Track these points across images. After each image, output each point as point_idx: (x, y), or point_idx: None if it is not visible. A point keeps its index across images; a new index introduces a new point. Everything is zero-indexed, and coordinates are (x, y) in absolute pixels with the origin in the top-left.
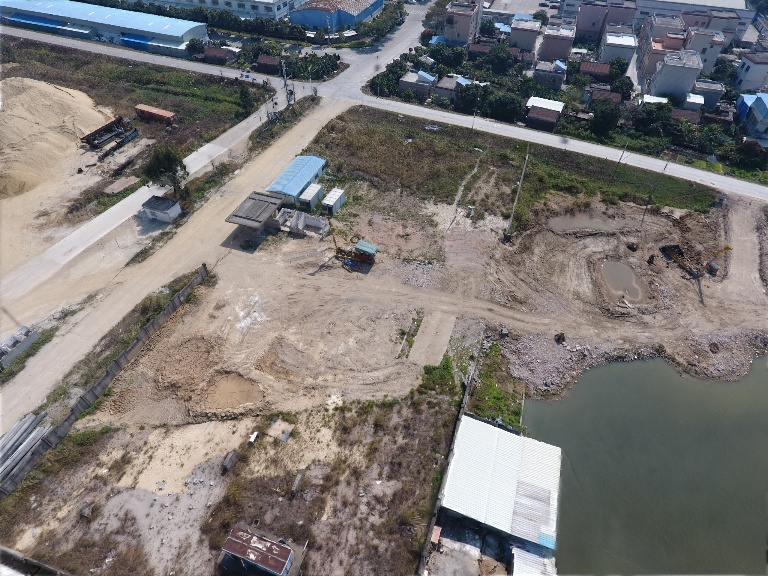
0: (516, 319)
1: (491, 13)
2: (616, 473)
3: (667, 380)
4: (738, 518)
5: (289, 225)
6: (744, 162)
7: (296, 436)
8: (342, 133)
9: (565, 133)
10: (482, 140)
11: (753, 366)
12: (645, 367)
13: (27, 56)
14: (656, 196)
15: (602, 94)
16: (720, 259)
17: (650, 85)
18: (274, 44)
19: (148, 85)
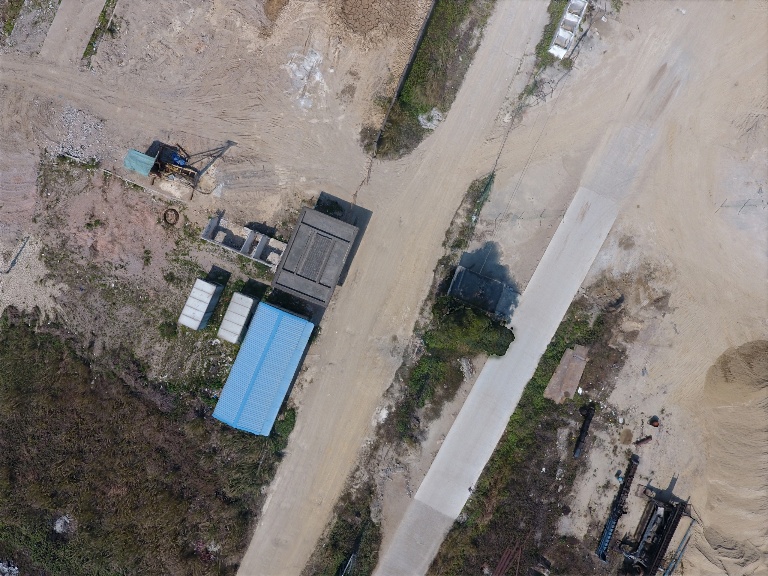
0: None
1: None
2: None
3: None
4: None
5: None
6: None
7: None
8: None
9: None
10: None
11: None
12: None
13: None
14: None
15: None
16: None
17: None
18: None
19: None
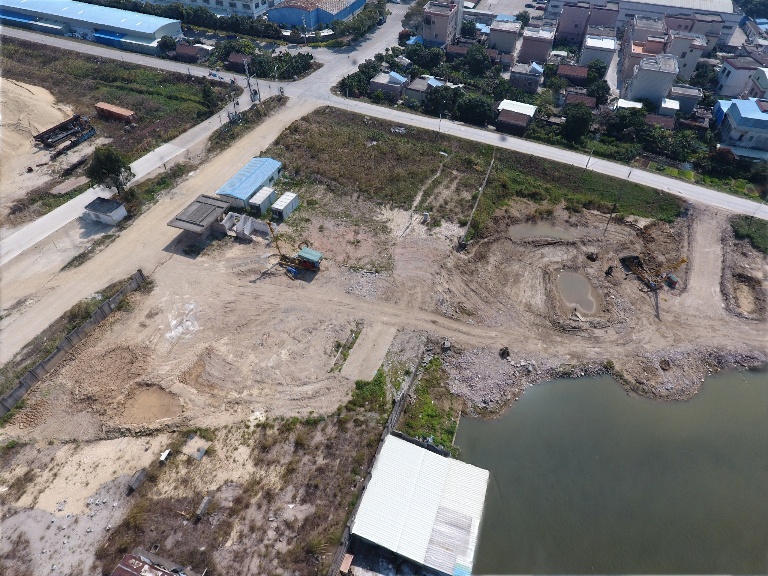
0: (461, 332)
1: (475, 13)
2: (548, 498)
3: (612, 399)
4: (671, 549)
5: (235, 230)
6: (716, 170)
7: (211, 454)
8: (305, 135)
9: (535, 137)
10: (448, 144)
11: (704, 385)
12: (591, 384)
13: None
14: (621, 204)
15: (576, 98)
16: (681, 271)
17: (627, 89)
18: (247, 42)
19: (114, 83)
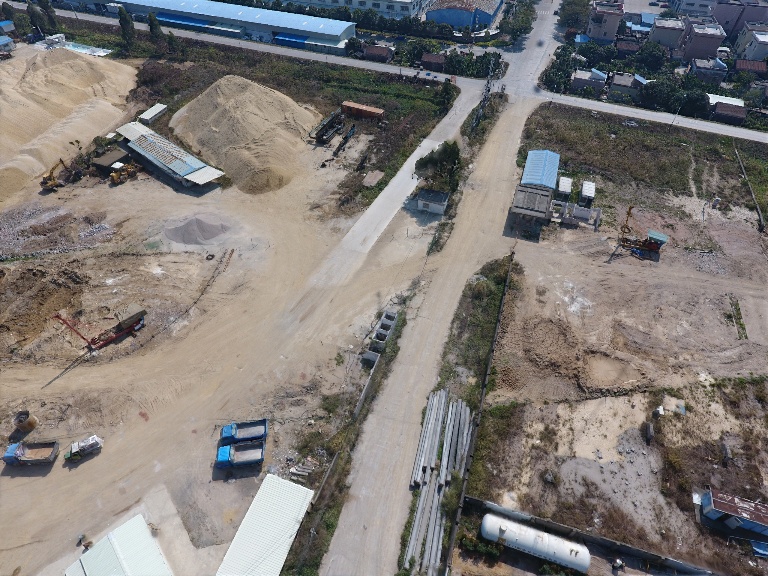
0: None
1: None
2: None
3: None
4: None
5: None
6: None
7: (691, 410)
8: None
9: (753, 128)
10: (684, 135)
11: None
12: None
13: (194, 55)
14: None
15: None
16: None
17: None
18: (433, 43)
19: (331, 83)
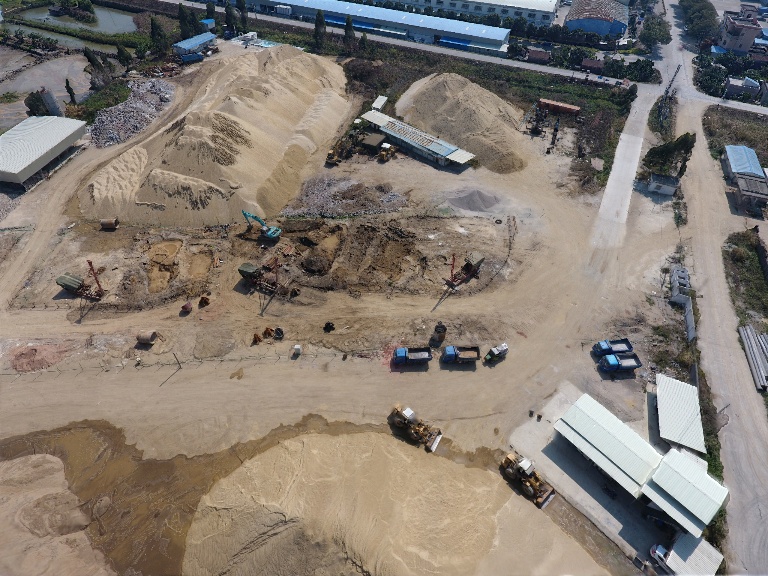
0: None
1: None
2: None
3: None
4: None
5: None
6: None
7: None
8: None
9: None
10: None
11: None
12: None
13: (375, 54)
14: None
15: None
16: None
17: None
18: (590, 49)
19: (513, 82)
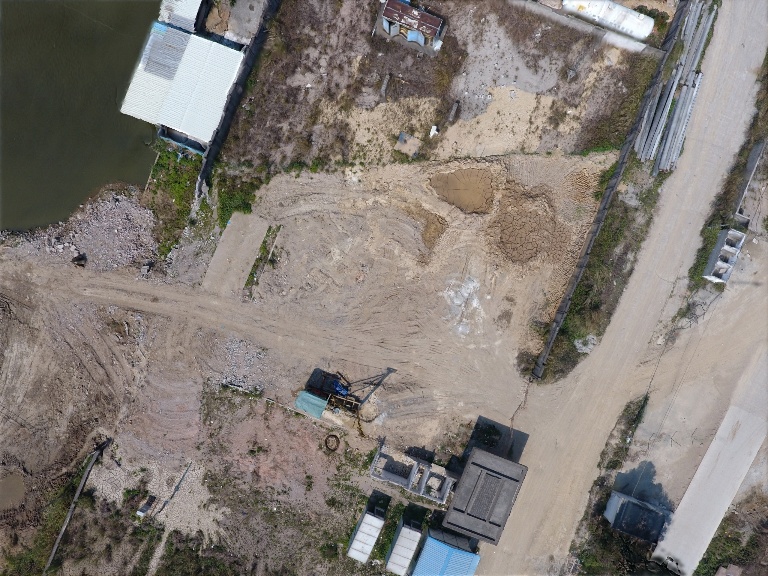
0: (127, 292)
1: None
2: (76, 101)
3: None
4: None
5: None
6: None
7: (392, 137)
8: None
9: None
10: None
11: None
12: None
13: None
14: None
15: None
16: None
17: None
18: None
19: None
